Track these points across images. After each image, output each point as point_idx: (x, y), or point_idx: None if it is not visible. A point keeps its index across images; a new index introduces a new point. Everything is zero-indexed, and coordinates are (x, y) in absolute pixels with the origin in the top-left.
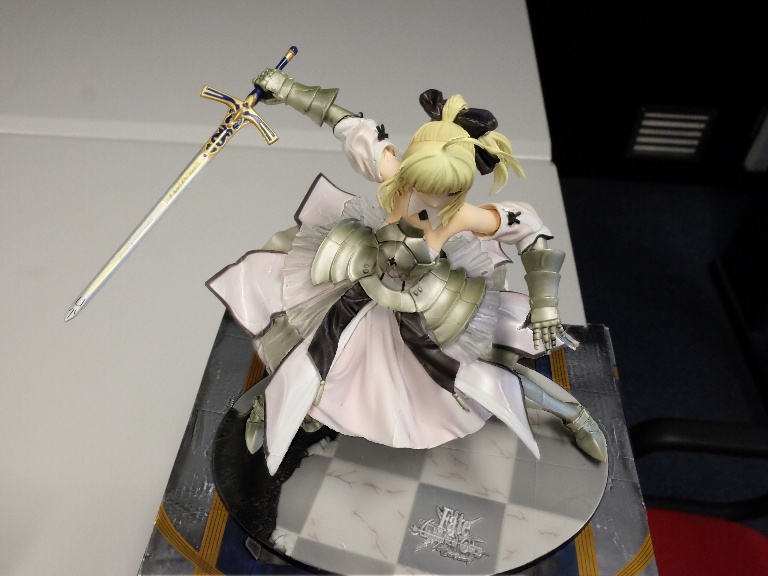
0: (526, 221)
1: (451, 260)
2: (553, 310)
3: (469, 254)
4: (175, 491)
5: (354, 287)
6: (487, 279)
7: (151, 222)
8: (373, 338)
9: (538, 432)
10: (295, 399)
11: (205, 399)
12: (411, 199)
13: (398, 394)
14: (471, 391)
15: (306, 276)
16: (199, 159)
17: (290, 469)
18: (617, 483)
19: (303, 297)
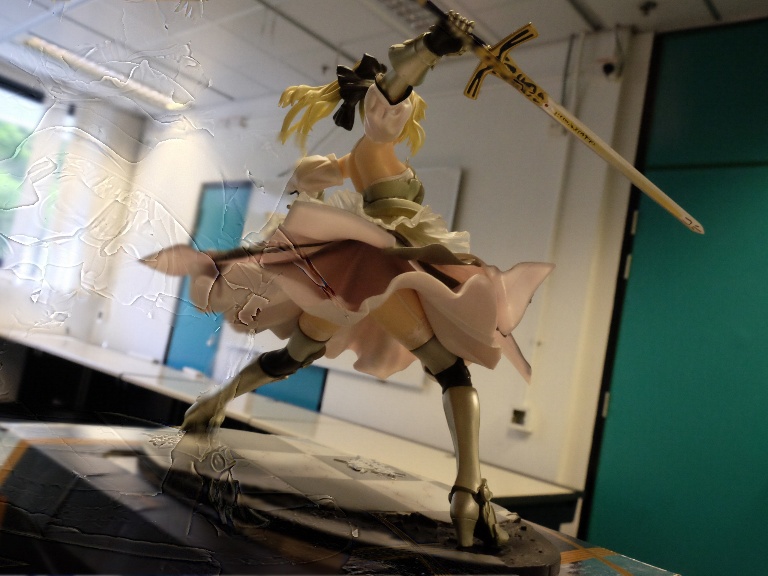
0: None
1: None
2: None
3: None
4: None
5: None
6: None
7: None
8: None
9: None
10: None
11: None
12: None
13: (191, 275)
14: (160, 249)
15: None
16: None
17: None
18: None
19: None
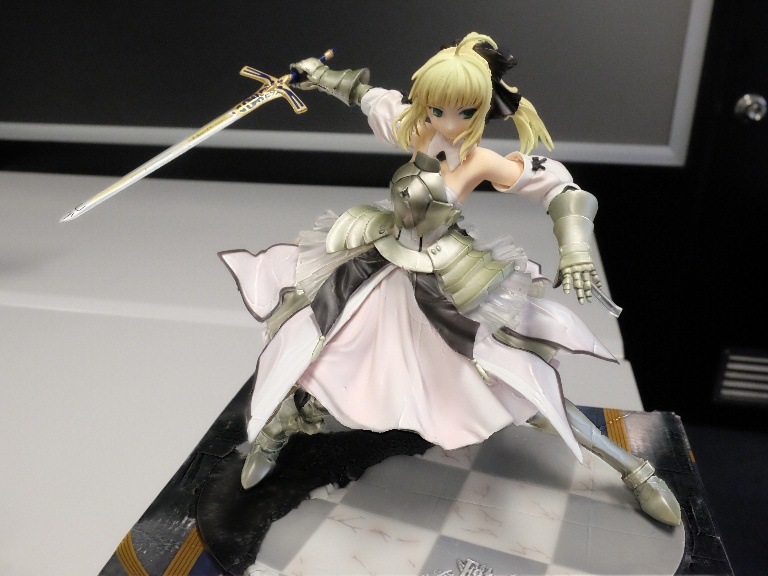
0: (552, 170)
1: (478, 247)
2: (585, 254)
3: (499, 248)
4: (149, 521)
5: (369, 250)
6: None
7: (169, 155)
8: (387, 315)
9: (592, 497)
10: (290, 358)
11: (208, 444)
12: (430, 145)
13: (411, 379)
14: (495, 369)
15: (322, 252)
16: (228, 115)
17: (286, 510)
18: (699, 560)
19: (316, 270)
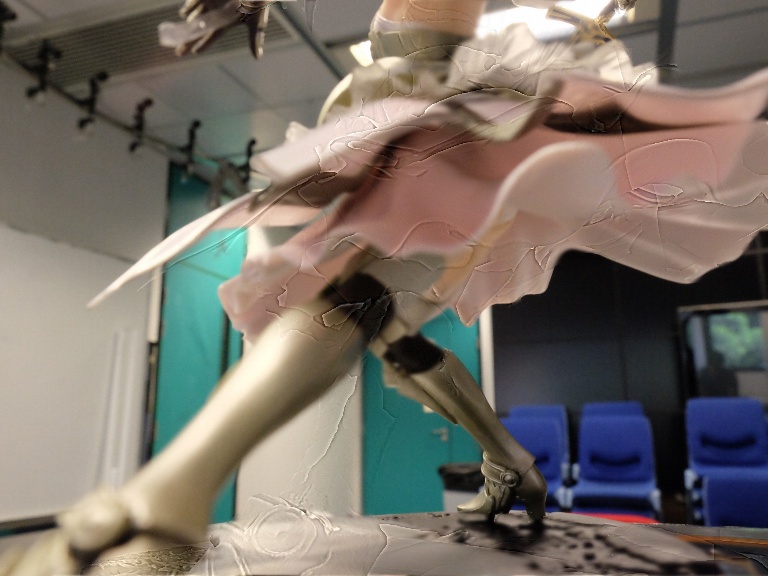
0: None
1: None
2: None
3: None
4: None
5: None
6: (513, 71)
7: None
8: None
9: None
10: None
11: None
12: None
13: None
14: None
15: None
16: None
17: None
18: None
19: None
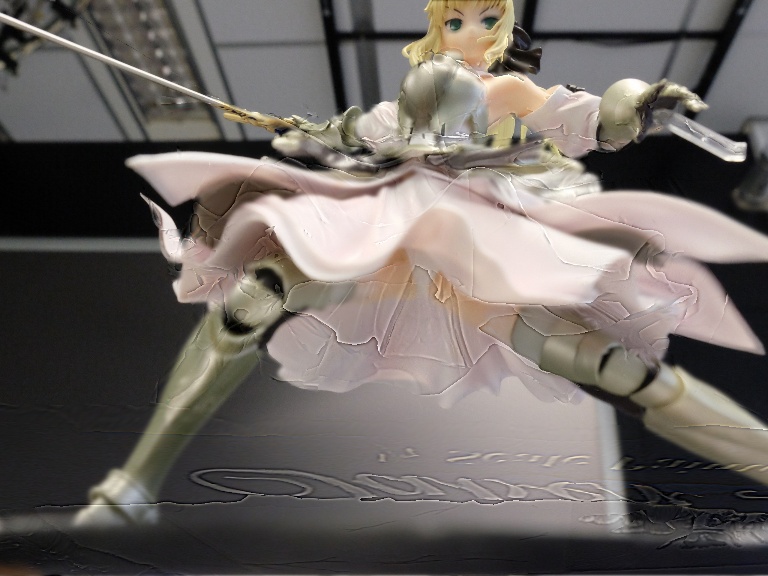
0: None
1: None
2: None
3: None
4: None
5: None
6: None
7: None
8: (398, 198)
9: None
10: None
11: None
12: None
13: None
14: None
15: None
16: None
17: (115, 573)
18: None
19: None
